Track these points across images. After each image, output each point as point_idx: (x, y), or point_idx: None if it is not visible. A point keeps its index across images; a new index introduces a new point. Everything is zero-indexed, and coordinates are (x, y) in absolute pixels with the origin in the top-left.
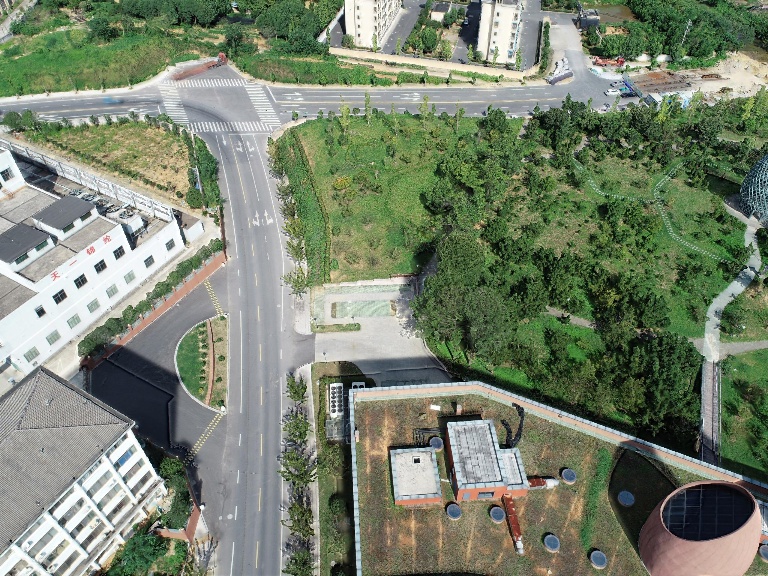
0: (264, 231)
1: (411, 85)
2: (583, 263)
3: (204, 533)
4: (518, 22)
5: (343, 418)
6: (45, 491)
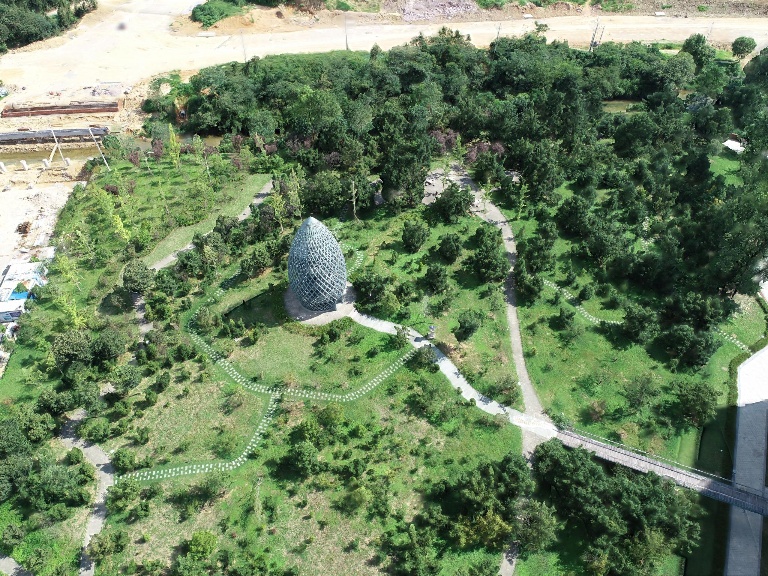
0: None
1: None
2: (415, 541)
3: None
4: None
5: None
6: None
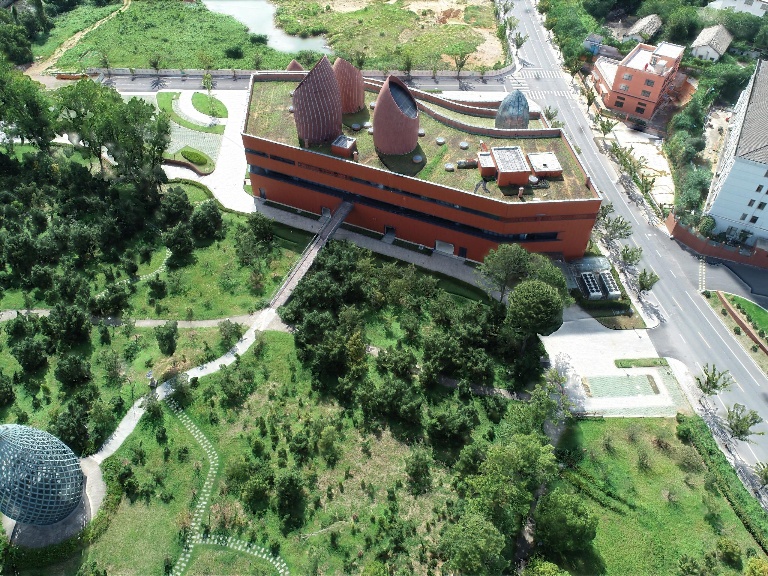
0: None
1: None
2: None
3: (661, 228)
4: None
5: (599, 281)
6: None
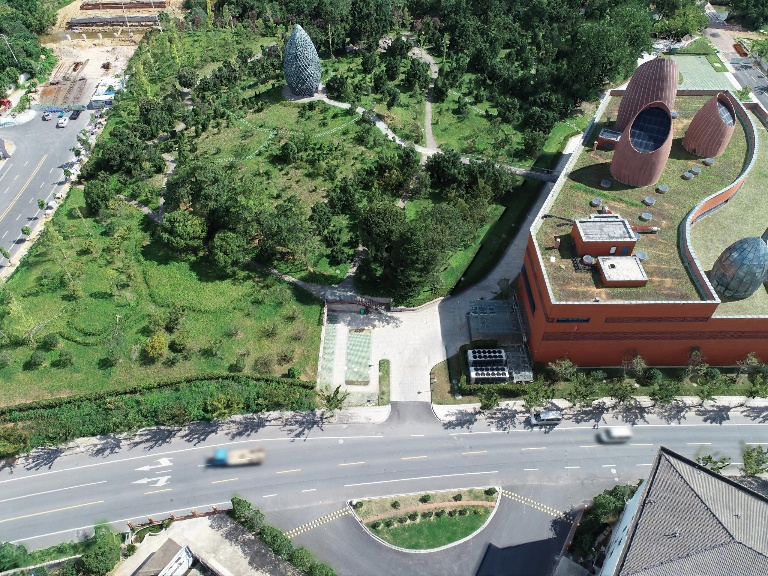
0: (186, 468)
1: None
2: None
3: None
4: None
5: None
6: (766, 511)
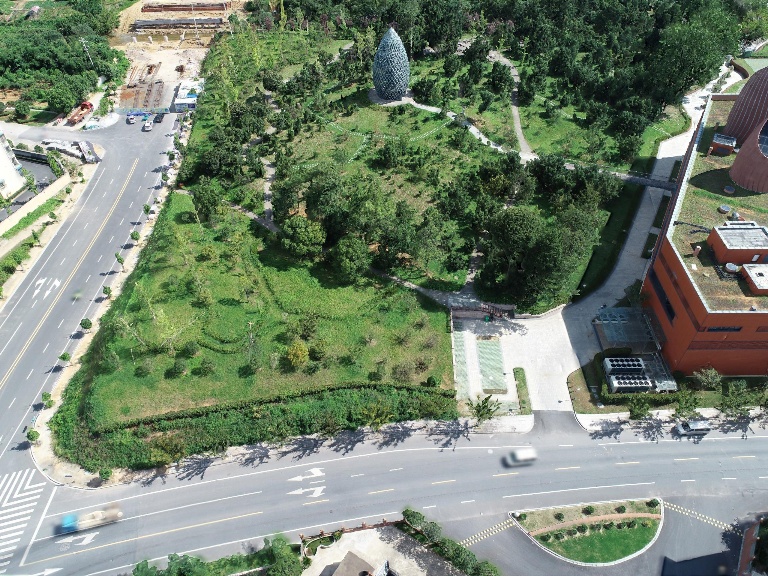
0: (339, 479)
1: (10, 285)
2: None
3: None
4: (2, 132)
5: None
6: None
